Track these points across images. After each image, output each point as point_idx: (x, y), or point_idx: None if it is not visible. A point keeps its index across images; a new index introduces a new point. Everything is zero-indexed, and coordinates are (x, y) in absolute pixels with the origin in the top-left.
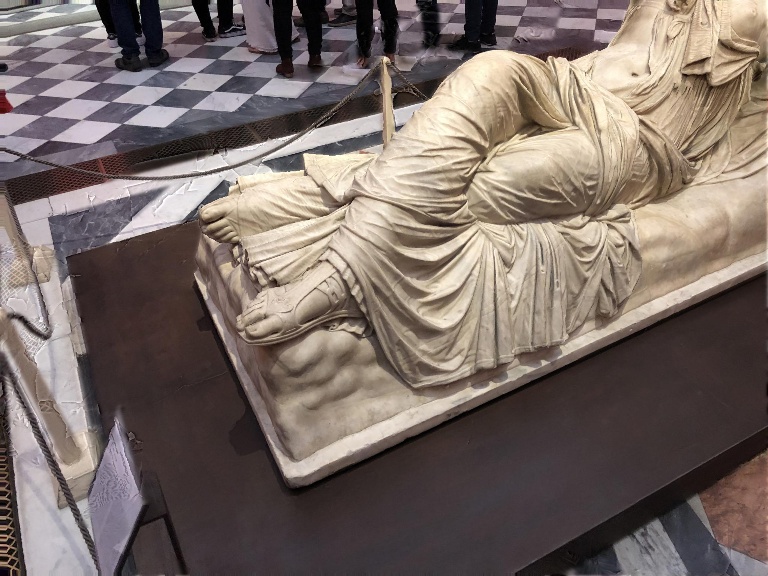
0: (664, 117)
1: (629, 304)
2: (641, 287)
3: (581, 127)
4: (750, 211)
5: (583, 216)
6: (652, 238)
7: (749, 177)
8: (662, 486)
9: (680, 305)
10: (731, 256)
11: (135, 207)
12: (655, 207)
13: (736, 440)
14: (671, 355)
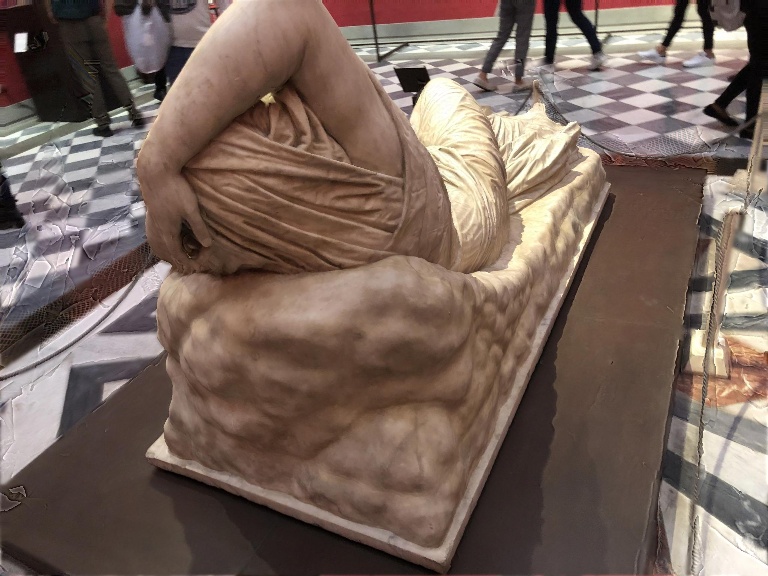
0: None
1: None
2: None
3: None
4: None
5: None
6: None
7: None
8: None
9: None
10: None
11: (729, 178)
12: None
13: None
14: None
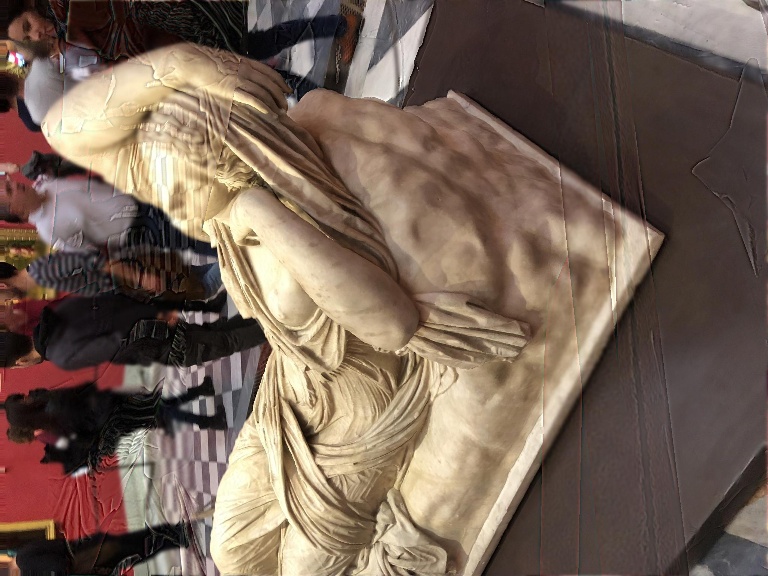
0: (345, 404)
1: (466, 545)
2: (461, 532)
3: None
4: (480, 424)
5: (364, 548)
6: (425, 513)
7: (458, 379)
8: None
9: (505, 520)
10: (515, 443)
11: None
12: (419, 455)
13: None
14: (523, 574)
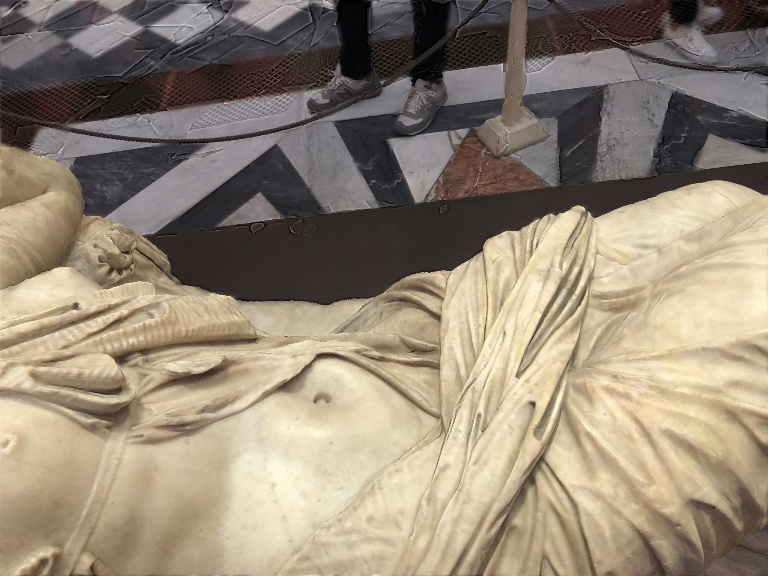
0: None
1: None
2: None
3: (596, 249)
4: None
5: None
6: None
7: None
8: (604, 181)
9: None
10: None
11: None
12: None
13: (513, 193)
14: None
